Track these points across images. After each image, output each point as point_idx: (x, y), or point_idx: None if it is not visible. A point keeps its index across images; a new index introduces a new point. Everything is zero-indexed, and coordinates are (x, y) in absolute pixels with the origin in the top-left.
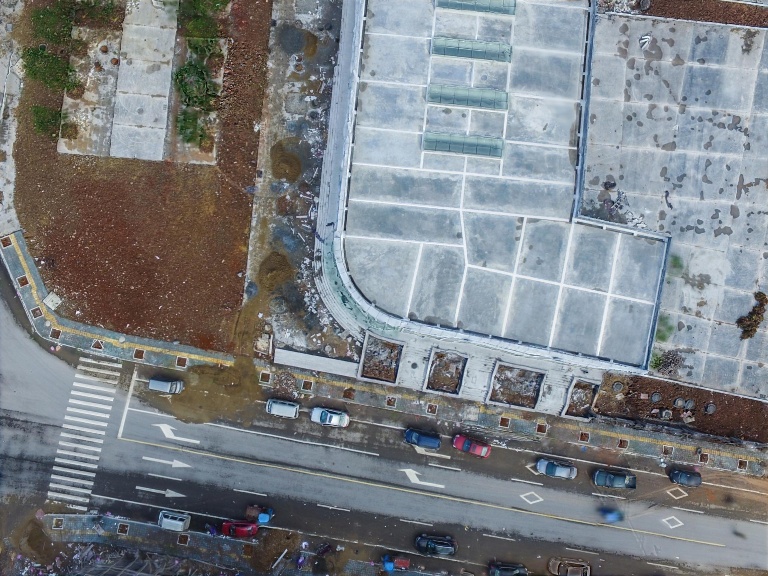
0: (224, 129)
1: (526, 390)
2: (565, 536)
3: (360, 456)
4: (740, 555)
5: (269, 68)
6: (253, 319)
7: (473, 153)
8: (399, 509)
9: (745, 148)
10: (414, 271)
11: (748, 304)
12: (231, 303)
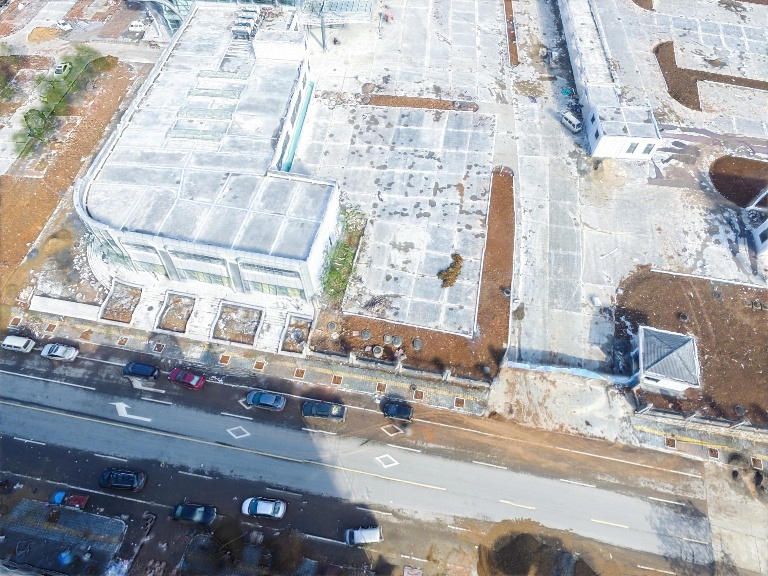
0: (58, 159)
1: (247, 329)
2: (267, 474)
3: (76, 390)
4: (464, 501)
5: (106, 130)
6: (25, 275)
7: (200, 139)
8: (97, 443)
9: (439, 168)
10: (136, 202)
11: (447, 262)
12: (11, 263)
